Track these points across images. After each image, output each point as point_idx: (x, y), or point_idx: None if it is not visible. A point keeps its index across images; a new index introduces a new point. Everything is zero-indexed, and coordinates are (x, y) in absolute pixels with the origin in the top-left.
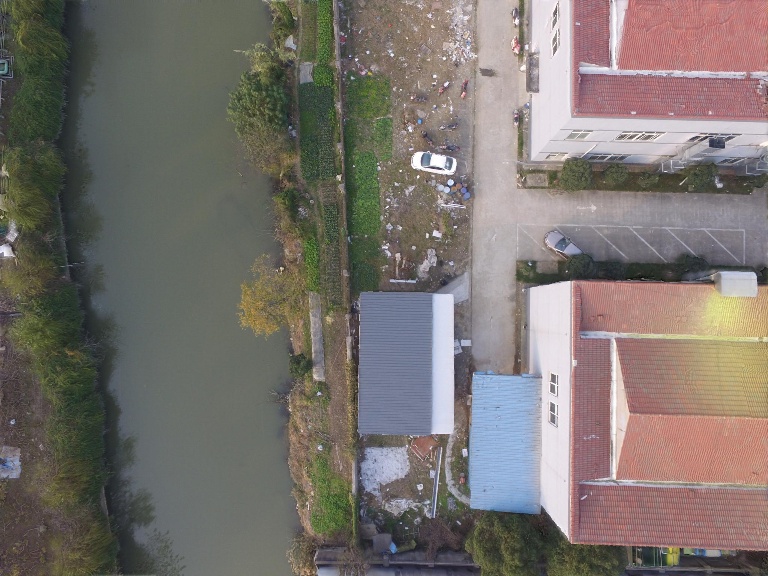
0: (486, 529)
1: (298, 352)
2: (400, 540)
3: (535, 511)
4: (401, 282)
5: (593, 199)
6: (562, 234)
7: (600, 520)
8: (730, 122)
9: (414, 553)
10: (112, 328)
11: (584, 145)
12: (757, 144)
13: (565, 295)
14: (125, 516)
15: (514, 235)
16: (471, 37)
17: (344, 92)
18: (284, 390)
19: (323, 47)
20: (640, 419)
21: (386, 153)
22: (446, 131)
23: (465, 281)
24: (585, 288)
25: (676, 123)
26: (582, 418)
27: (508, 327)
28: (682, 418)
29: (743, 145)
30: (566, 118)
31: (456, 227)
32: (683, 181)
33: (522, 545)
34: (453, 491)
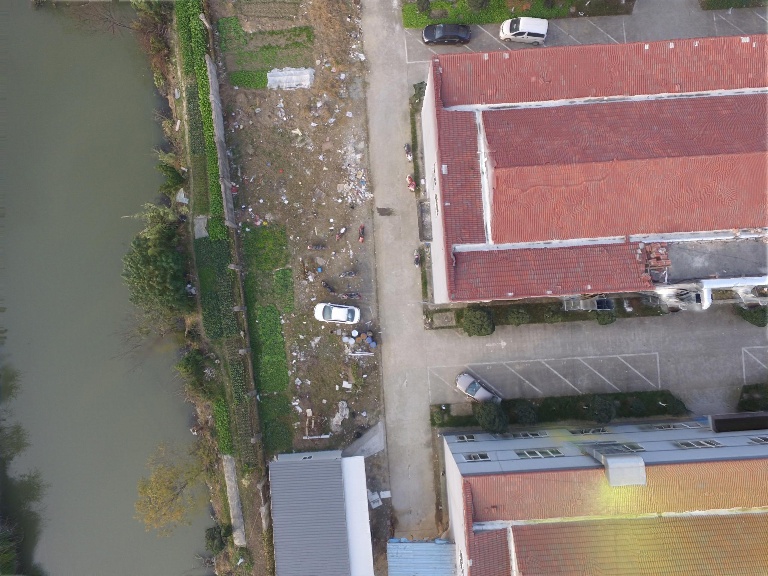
0: None
1: (218, 516)
2: None
3: None
4: (314, 438)
5: (502, 334)
6: (474, 374)
7: None
8: None
9: None
10: (33, 498)
11: None
12: (651, 290)
13: (459, 483)
14: None
15: (425, 379)
16: (365, 176)
17: (240, 245)
18: (209, 553)
19: (215, 199)
20: None
21: (288, 305)
22: (347, 278)
23: (379, 431)
24: (475, 483)
25: None
26: None
27: (426, 474)
28: None
29: (638, 291)
30: (446, 298)
31: (366, 376)
32: None
33: None
34: None
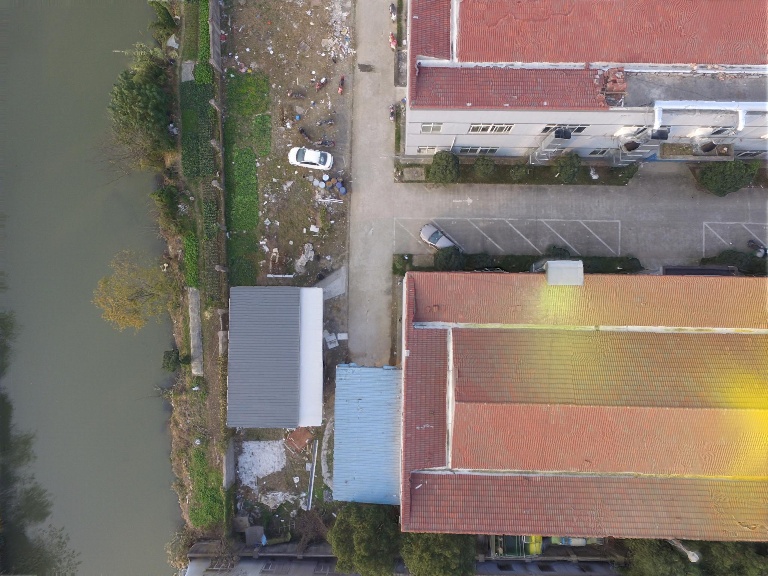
0: (344, 520)
1: (179, 347)
2: (276, 532)
3: (395, 502)
4: (278, 277)
5: (469, 192)
6: (438, 227)
7: (432, 508)
8: (567, 112)
9: (287, 545)
10: (4, 326)
11: (445, 138)
12: (611, 134)
13: None
14: (13, 512)
15: (391, 229)
16: (350, 33)
17: (224, 90)
18: (167, 385)
19: (204, 45)
20: (466, 408)
21: (265, 149)
22: (323, 127)
23: (342, 275)
24: (419, 279)
25: (515, 114)
26: (415, 407)
27: (384, 320)
28: (507, 406)
29: (598, 136)
30: None
31: (333, 222)
32: (558, 173)
33: (370, 535)
34: (329, 483)
